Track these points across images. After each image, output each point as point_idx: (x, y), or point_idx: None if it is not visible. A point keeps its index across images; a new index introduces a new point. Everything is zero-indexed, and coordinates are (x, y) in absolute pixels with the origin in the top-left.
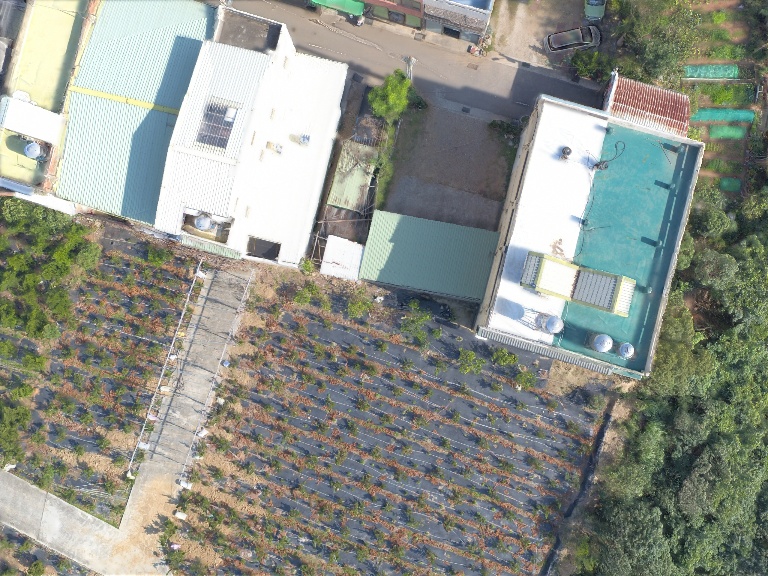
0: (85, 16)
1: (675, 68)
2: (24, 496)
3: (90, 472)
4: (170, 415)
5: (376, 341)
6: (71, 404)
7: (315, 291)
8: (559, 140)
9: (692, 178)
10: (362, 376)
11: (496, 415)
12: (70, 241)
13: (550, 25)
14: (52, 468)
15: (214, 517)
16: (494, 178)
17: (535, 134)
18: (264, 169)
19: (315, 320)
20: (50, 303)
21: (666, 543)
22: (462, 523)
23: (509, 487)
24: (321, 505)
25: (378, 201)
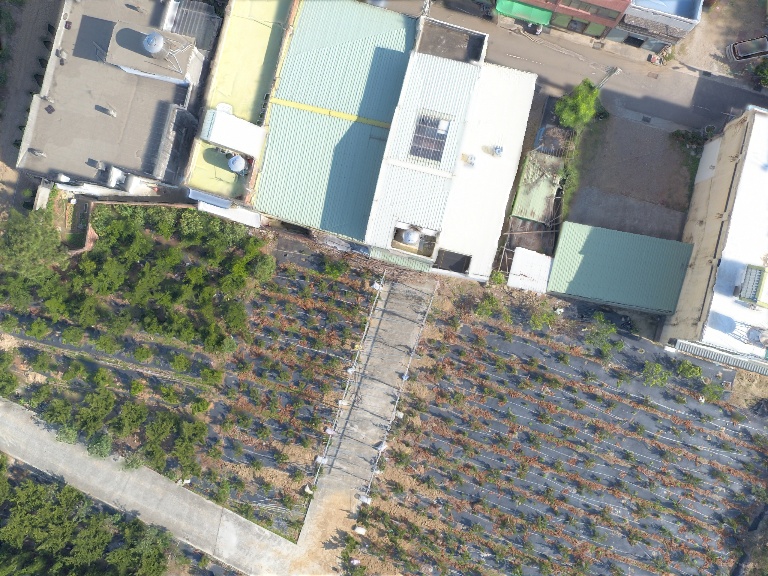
0: (285, 27)
1: None
2: (199, 511)
3: (269, 487)
4: (348, 429)
5: (557, 353)
6: (248, 418)
7: (495, 303)
8: None
9: None
10: (543, 389)
11: (680, 428)
12: (251, 254)
13: (731, 33)
14: (228, 483)
15: (394, 532)
16: (676, 188)
17: (747, 145)
18: (457, 181)
19: (495, 332)
20: None
21: None
22: (646, 537)
23: (694, 500)
24: (502, 519)
25: (564, 212)
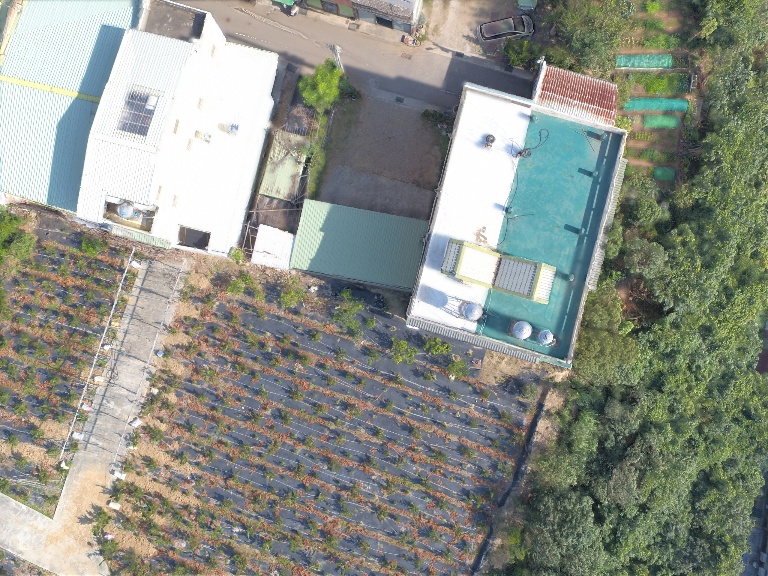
0: (10, 5)
1: (604, 57)
2: None
3: (23, 462)
4: (104, 405)
5: (310, 331)
6: (5, 394)
7: (249, 281)
8: (483, 128)
9: (615, 166)
10: (296, 366)
11: (429, 405)
12: (2, 231)
13: (484, 15)
14: None
15: (148, 507)
16: (427, 168)
17: (458, 122)
18: (193, 158)
19: (249, 310)
20: None
21: (597, 532)
22: (395, 513)
23: (442, 477)
24: (255, 495)
25: (310, 190)
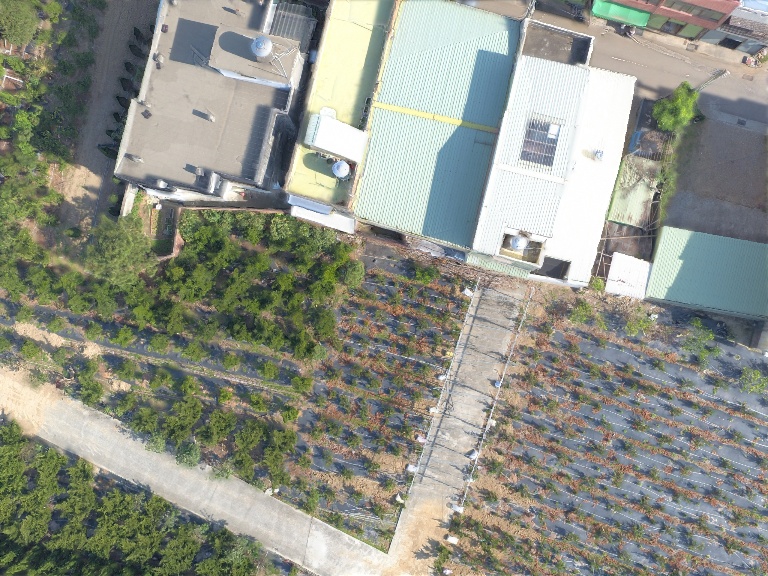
0: (388, 30)
1: None
2: (288, 521)
3: (361, 496)
4: (439, 437)
5: (652, 360)
6: (338, 426)
7: (589, 309)
8: None
9: None
10: (638, 396)
11: None
12: (343, 260)
13: None
14: (317, 492)
15: (487, 541)
16: None
17: None
18: None
19: (588, 339)
20: (317, 323)
21: None
22: (743, 546)
23: None
24: (597, 528)
25: (662, 217)
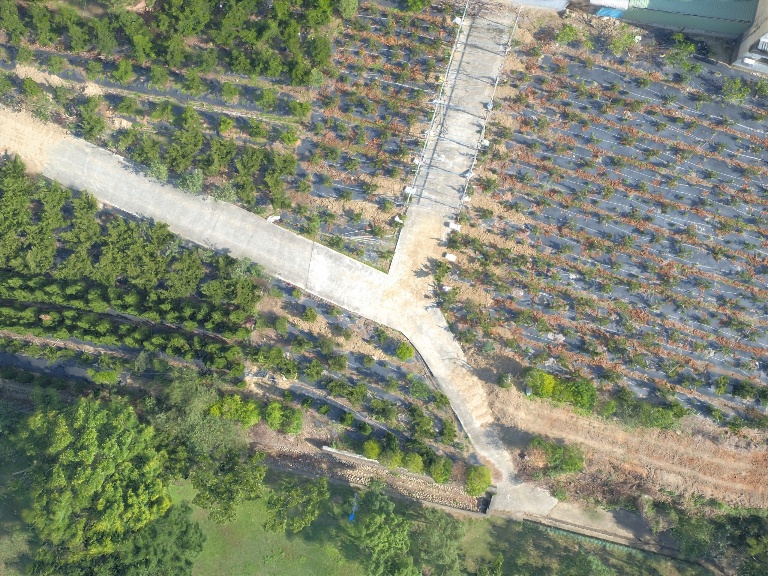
0: None
1: None
2: (290, 246)
3: (360, 215)
4: (435, 159)
5: (637, 79)
6: None
7: (575, 31)
8: None
9: None
10: (625, 113)
11: (759, 146)
12: None
13: None
14: (318, 217)
15: (484, 257)
16: None
17: None
18: None
19: (575, 61)
20: (314, 49)
21: None
22: (730, 253)
23: None
24: (590, 242)
25: None
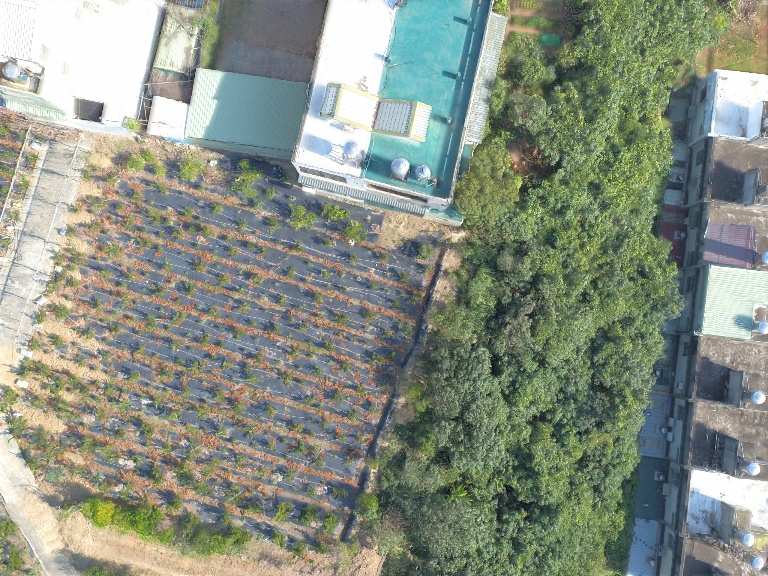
0: None
1: None
2: None
3: None
4: (9, 285)
5: (210, 203)
6: None
7: (148, 157)
8: None
9: (488, 12)
10: (198, 238)
11: (330, 270)
12: None
13: None
14: None
15: (56, 384)
16: None
17: None
18: (82, 28)
19: (150, 186)
20: None
21: (495, 382)
22: (301, 377)
23: (346, 340)
24: (162, 367)
25: (202, 62)
